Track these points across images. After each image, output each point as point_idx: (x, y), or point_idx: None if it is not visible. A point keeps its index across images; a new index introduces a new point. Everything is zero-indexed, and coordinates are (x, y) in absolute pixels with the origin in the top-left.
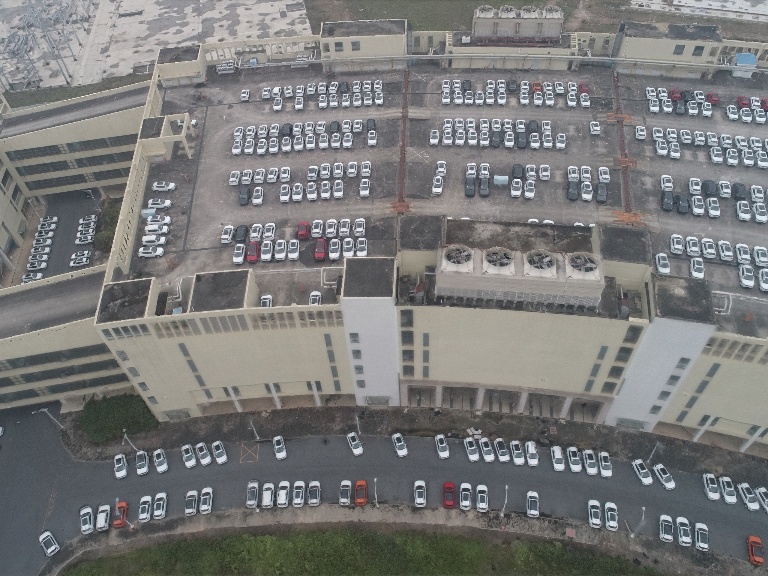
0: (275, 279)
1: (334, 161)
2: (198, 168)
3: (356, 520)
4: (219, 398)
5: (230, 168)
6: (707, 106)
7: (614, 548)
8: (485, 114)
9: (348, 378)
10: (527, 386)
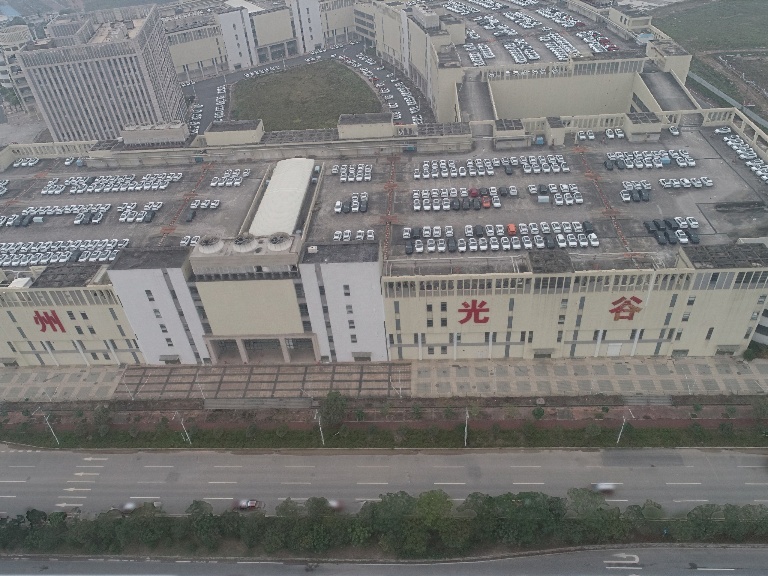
0: None
1: None
2: None
3: None
4: None
5: None
6: None
7: (383, 109)
8: None
9: None
10: (421, 72)
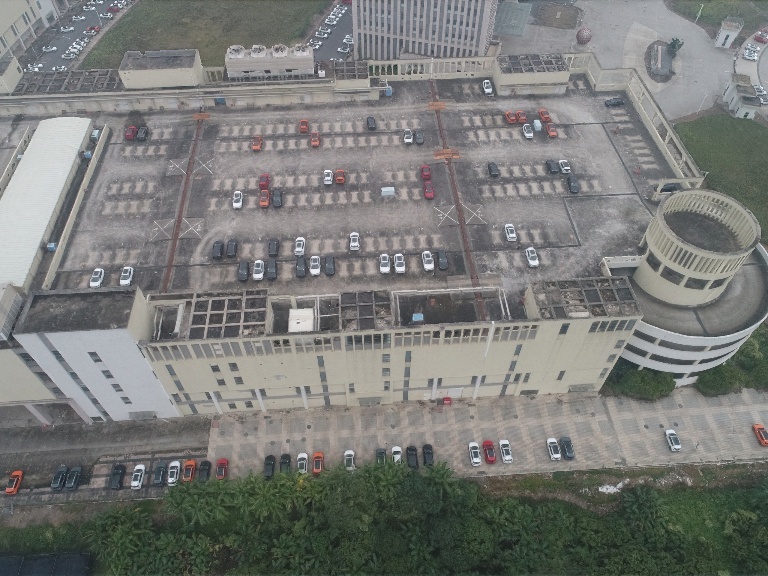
0: None
1: None
2: None
3: (104, 33)
4: (3, 51)
5: None
6: None
7: None
8: None
9: (33, 3)
10: None
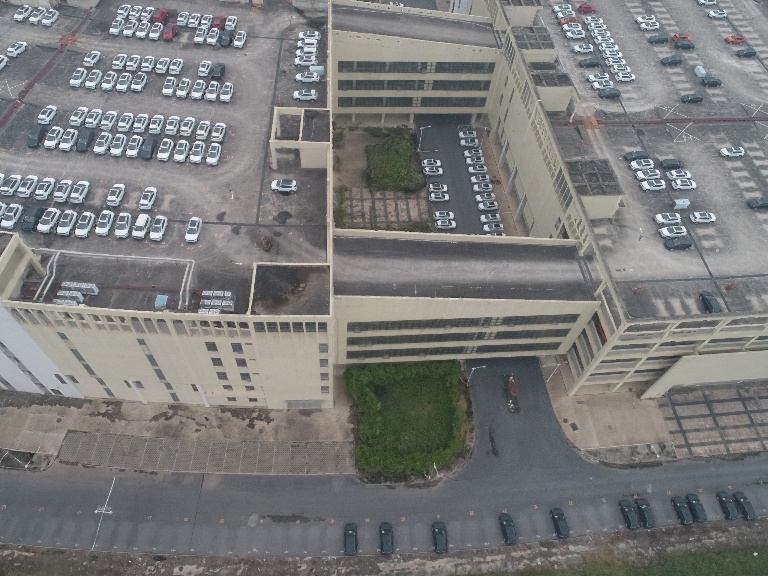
0: (205, 7)
1: (109, 99)
2: (270, 120)
3: None
4: None
5: (232, 112)
6: None
7: None
8: None
9: None
10: None
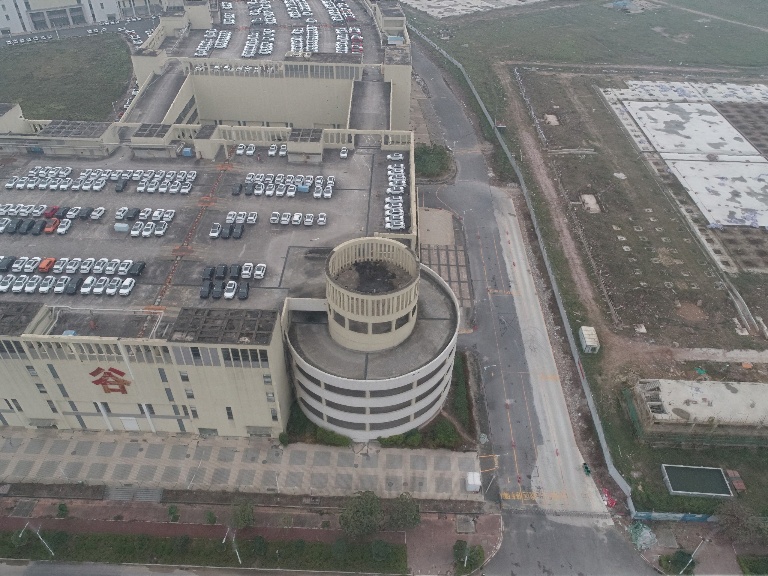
0: None
1: None
2: None
3: None
4: None
5: None
6: (343, 36)
7: None
8: (317, 7)
9: None
10: None
